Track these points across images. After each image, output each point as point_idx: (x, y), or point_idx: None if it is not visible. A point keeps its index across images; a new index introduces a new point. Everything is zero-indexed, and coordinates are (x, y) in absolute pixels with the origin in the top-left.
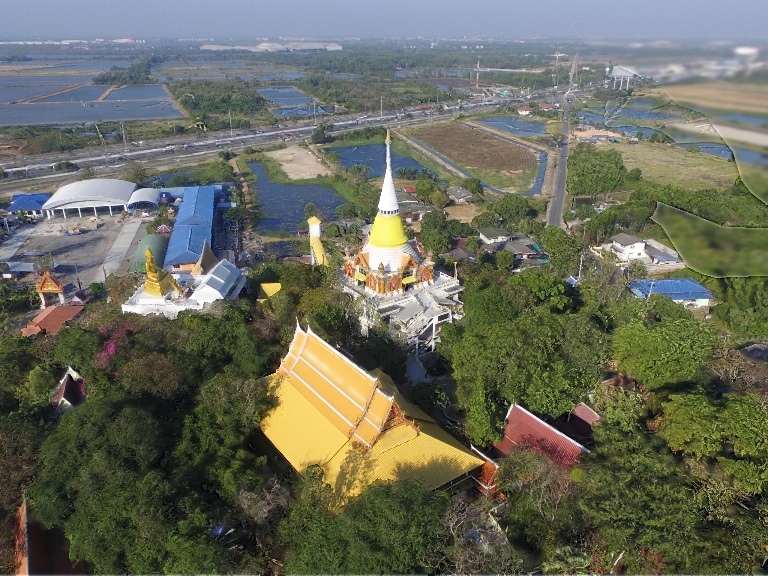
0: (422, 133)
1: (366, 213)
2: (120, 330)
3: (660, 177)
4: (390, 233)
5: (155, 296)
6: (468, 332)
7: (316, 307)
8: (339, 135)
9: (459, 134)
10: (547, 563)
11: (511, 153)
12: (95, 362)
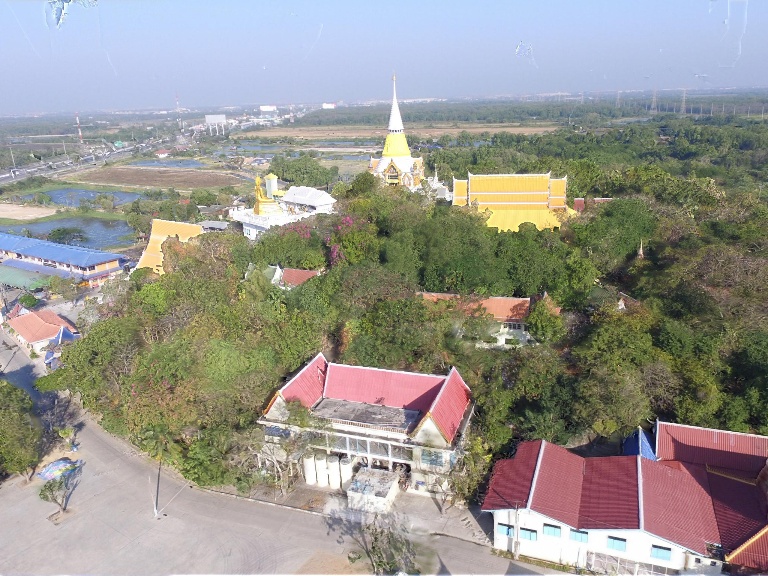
0: (90, 178)
1: (185, 215)
2: (298, 229)
3: (347, 172)
4: (405, 145)
5: (277, 214)
6: (530, 166)
7: (402, 193)
8: (3, 187)
9: (130, 174)
10: (678, 210)
11: (207, 177)
12: (345, 230)
